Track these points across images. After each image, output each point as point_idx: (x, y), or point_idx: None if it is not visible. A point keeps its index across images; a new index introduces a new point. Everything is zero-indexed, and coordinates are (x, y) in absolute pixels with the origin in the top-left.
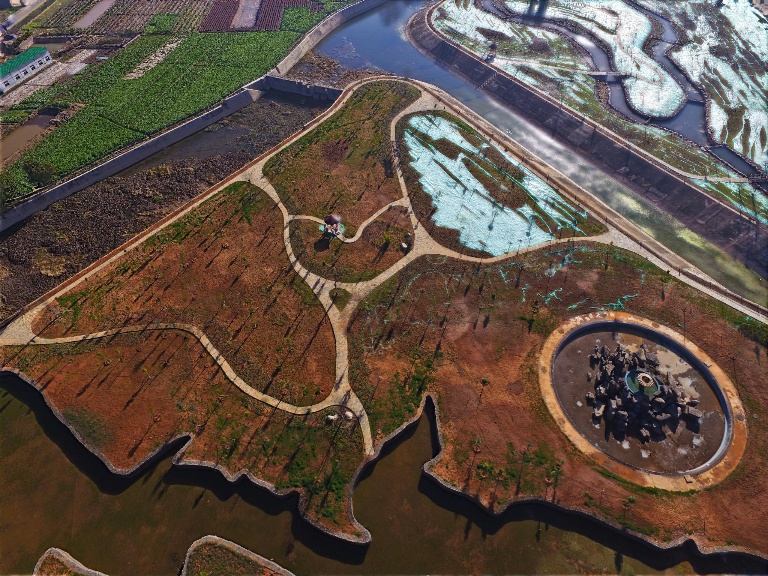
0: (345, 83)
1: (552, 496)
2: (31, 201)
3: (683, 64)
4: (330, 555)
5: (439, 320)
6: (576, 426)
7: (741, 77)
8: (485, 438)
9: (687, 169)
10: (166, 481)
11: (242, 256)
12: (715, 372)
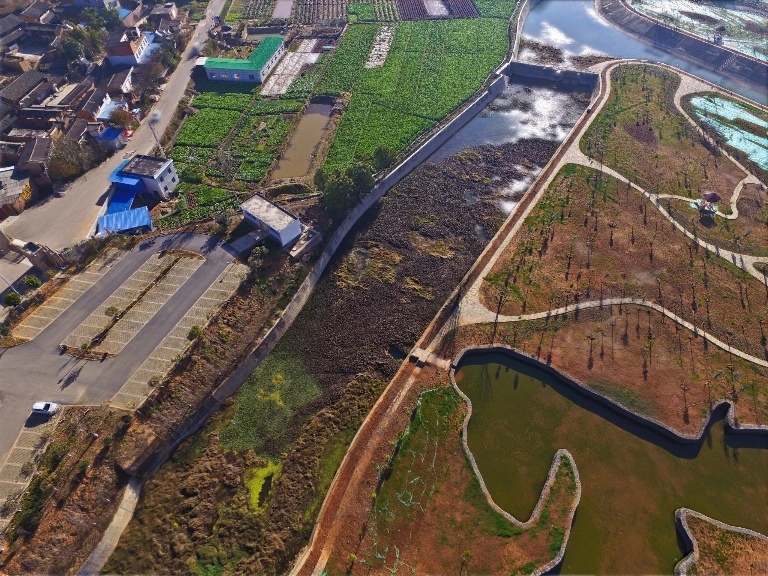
0: (583, 67)
1: None
2: (377, 187)
3: None
4: None
5: None
6: None
7: None
8: None
9: None
10: (730, 445)
11: (638, 234)
12: None
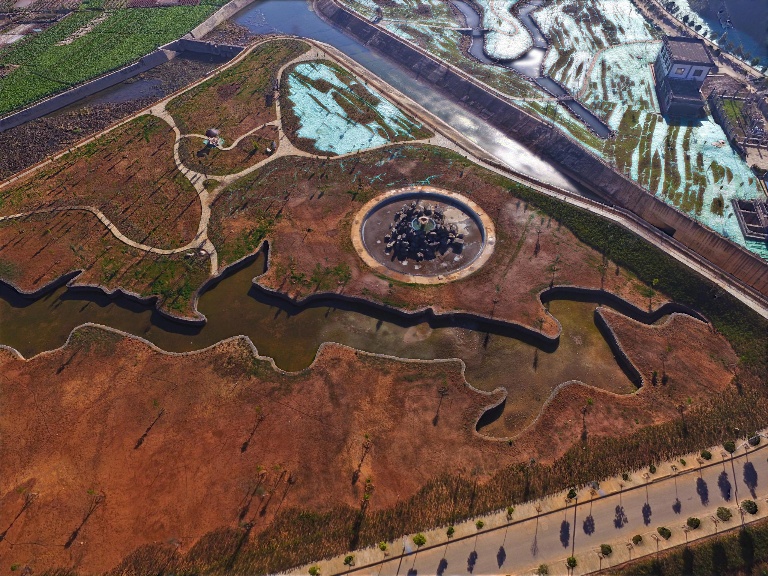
0: None
1: (340, 291)
2: None
3: (539, 20)
4: (176, 331)
5: (285, 195)
6: (372, 254)
7: (580, 27)
8: (301, 261)
9: (512, 94)
10: (62, 298)
11: None
12: (483, 218)
